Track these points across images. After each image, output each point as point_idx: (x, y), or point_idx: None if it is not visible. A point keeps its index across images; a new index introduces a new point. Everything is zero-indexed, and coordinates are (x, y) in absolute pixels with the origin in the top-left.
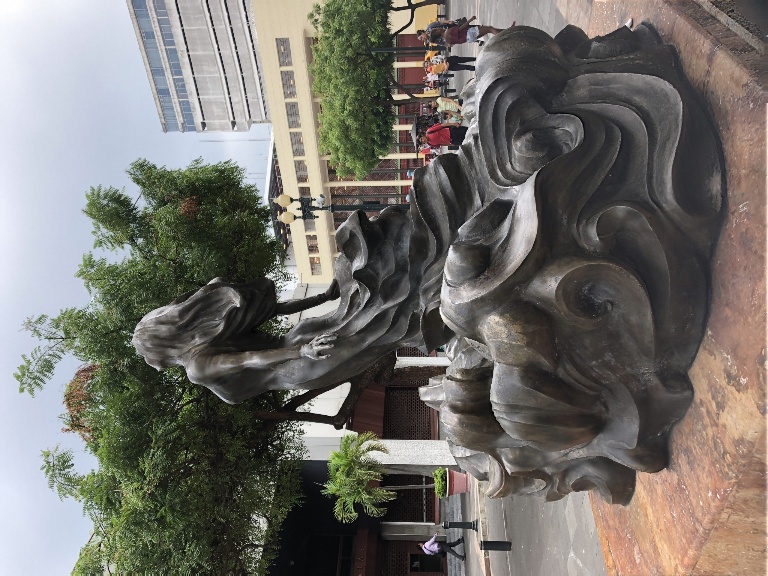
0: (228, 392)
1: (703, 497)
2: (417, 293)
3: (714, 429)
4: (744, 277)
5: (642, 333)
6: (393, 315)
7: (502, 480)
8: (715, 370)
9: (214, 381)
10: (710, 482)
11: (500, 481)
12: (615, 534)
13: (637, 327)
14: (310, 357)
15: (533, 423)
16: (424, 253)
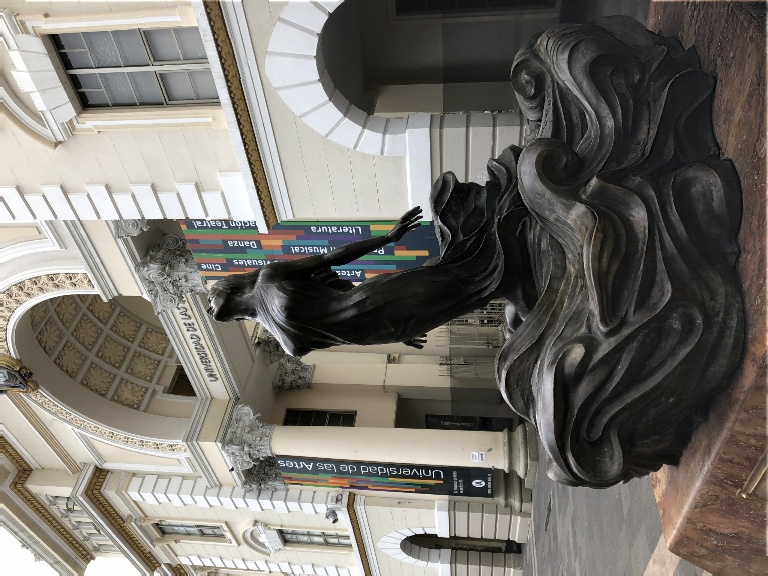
0: (290, 288)
1: (719, 8)
2: (492, 223)
3: (700, 8)
4: (670, 2)
5: (635, 31)
6: (470, 243)
7: (595, 218)
8: (687, 19)
9: (283, 276)
10: (714, 1)
11: (593, 219)
12: (761, 229)
13: (631, 31)
14: (393, 232)
15: (579, 32)
16: (498, 190)
